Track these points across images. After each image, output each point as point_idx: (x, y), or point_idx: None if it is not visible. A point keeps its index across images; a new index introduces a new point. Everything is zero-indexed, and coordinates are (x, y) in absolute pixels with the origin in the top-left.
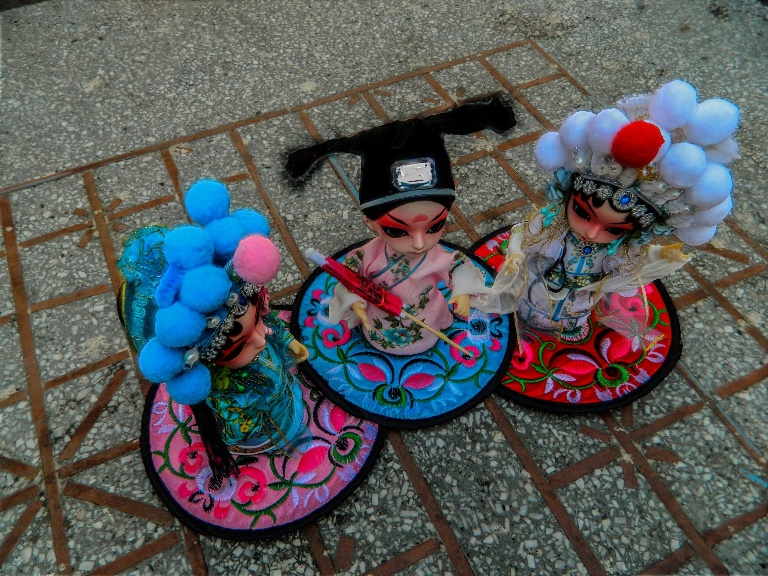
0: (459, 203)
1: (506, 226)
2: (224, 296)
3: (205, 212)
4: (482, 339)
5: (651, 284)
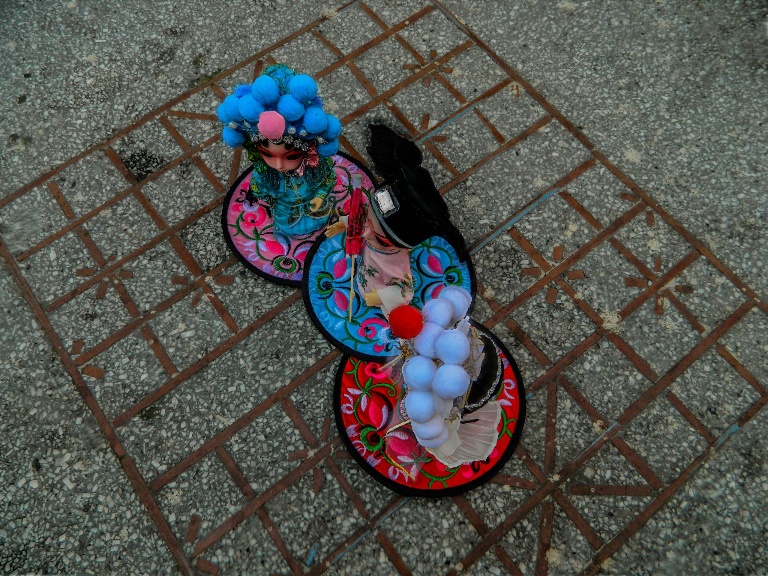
0: (525, 307)
1: None
2: (249, 118)
3: (290, 87)
4: (383, 338)
5: (474, 477)
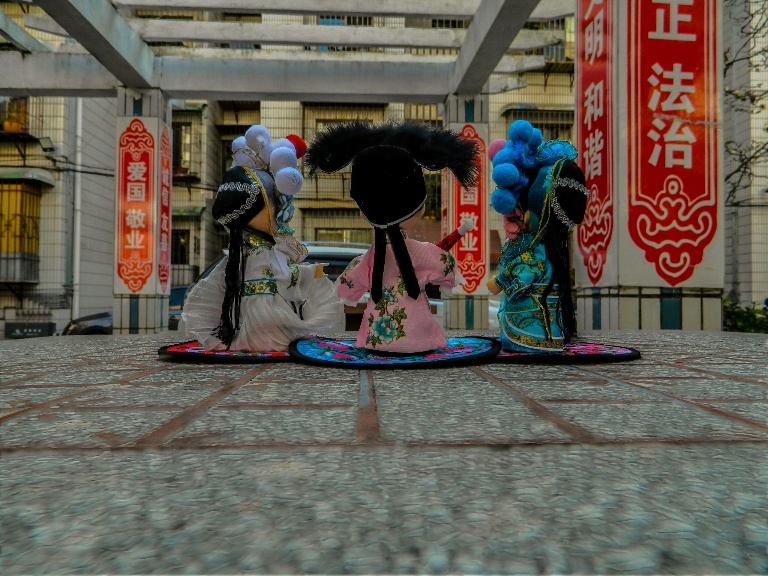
0: None
1: (232, 356)
2: None
3: None
4: None
5: None
